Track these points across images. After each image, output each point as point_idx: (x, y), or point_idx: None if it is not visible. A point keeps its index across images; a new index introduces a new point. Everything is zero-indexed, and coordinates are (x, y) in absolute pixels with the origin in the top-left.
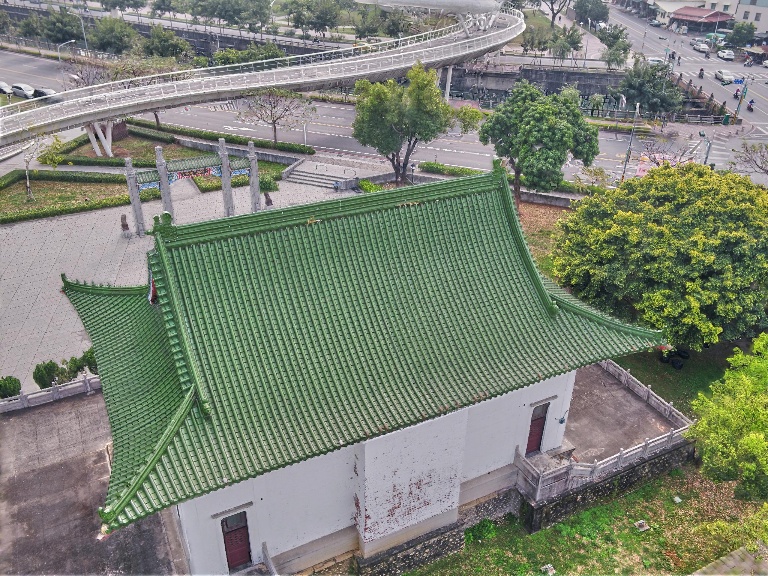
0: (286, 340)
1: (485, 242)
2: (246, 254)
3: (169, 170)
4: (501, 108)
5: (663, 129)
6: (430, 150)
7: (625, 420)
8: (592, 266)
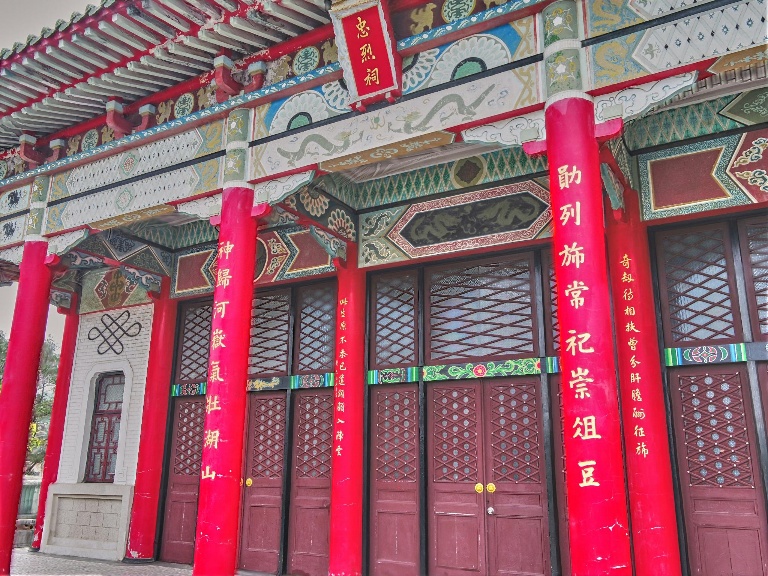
0: None
1: None
2: None
3: None
4: None
5: None
6: None
7: None
8: None
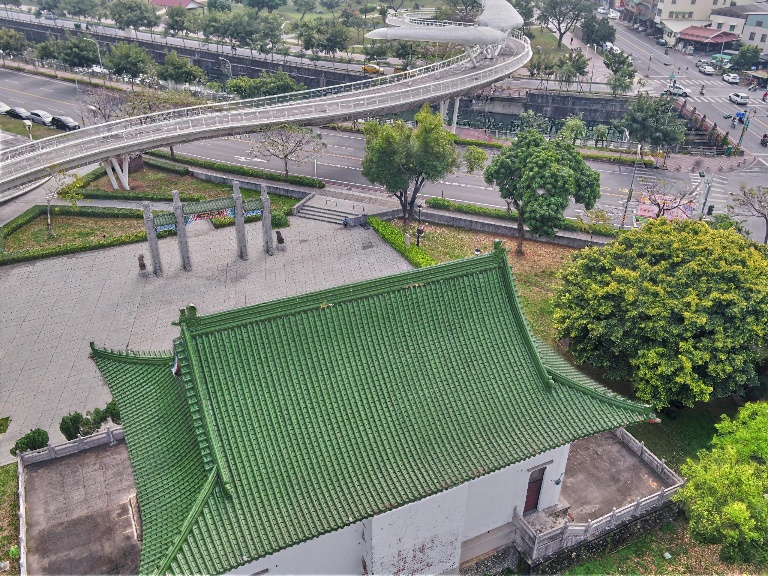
0: (300, 419)
1: (486, 318)
2: (264, 339)
3: (185, 213)
4: (506, 152)
5: (666, 161)
6: (437, 184)
7: (619, 476)
8: (590, 320)
